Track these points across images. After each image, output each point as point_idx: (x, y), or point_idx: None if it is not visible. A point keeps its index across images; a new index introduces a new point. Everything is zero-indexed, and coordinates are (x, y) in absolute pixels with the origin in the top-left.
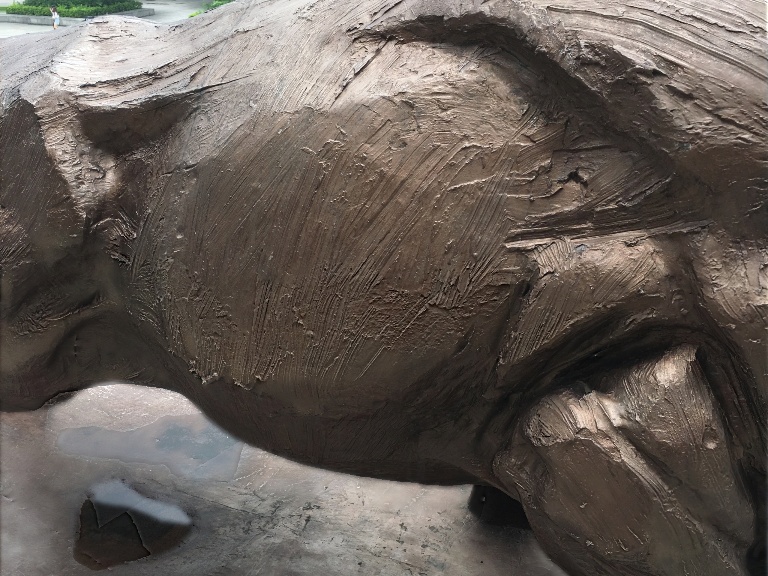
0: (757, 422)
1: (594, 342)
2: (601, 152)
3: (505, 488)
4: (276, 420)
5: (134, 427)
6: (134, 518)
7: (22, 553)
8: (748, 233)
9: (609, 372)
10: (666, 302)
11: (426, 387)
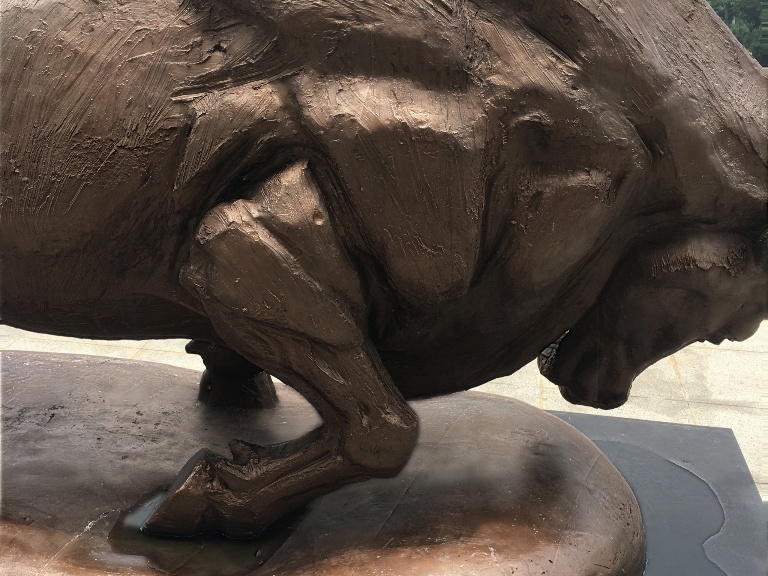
0: (349, 206)
1: (238, 163)
2: (234, 28)
3: (195, 307)
4: (3, 266)
5: None
6: None
7: None
8: (328, 71)
9: (253, 187)
10: (282, 125)
11: (122, 219)
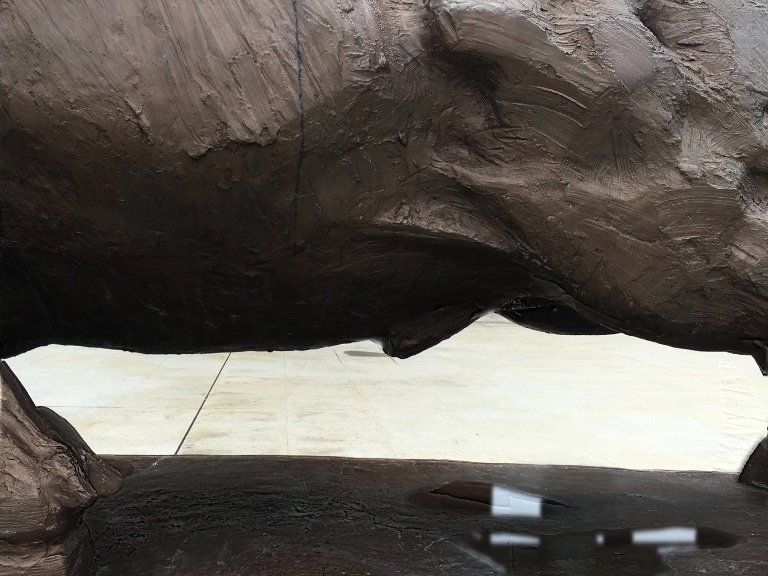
0: None
1: None
2: None
3: None
4: None
5: (677, 556)
6: (493, 506)
7: (535, 477)
8: None
9: None
10: None
11: None
